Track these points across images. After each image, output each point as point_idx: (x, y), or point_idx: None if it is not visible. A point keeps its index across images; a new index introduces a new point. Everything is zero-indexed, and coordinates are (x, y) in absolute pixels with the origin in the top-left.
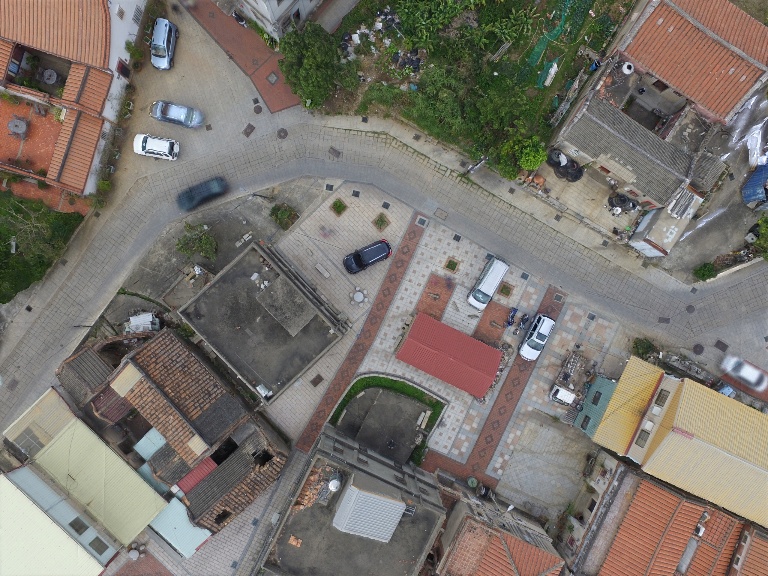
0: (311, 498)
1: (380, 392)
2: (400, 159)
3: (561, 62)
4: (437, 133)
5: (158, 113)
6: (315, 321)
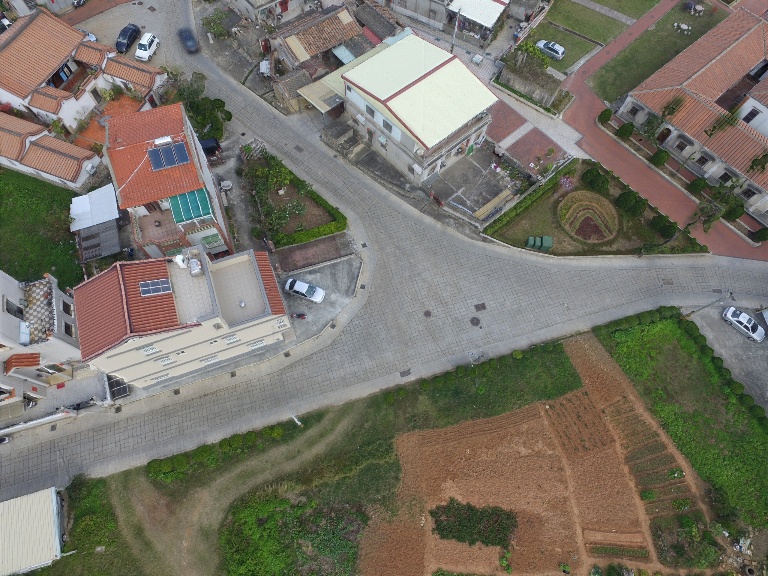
0: None
1: None
2: None
3: None
4: None
5: (125, 42)
6: None
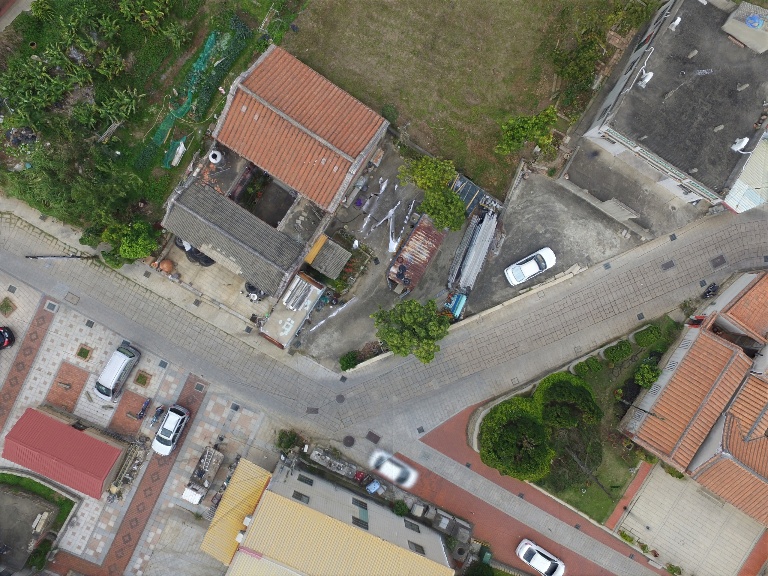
0: None
1: None
2: (27, 240)
3: (189, 141)
4: (53, 215)
5: None
6: None
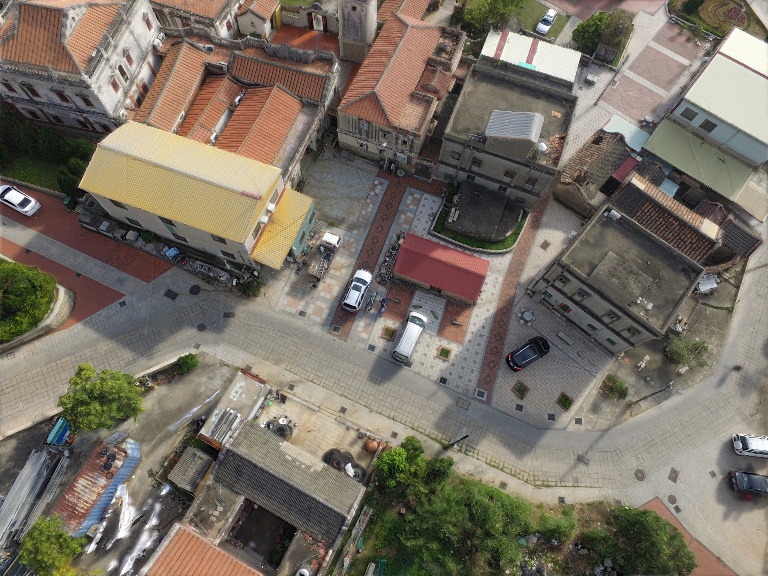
0: (553, 142)
1: None
2: (515, 459)
3: None
4: None
5: None
6: (586, 273)
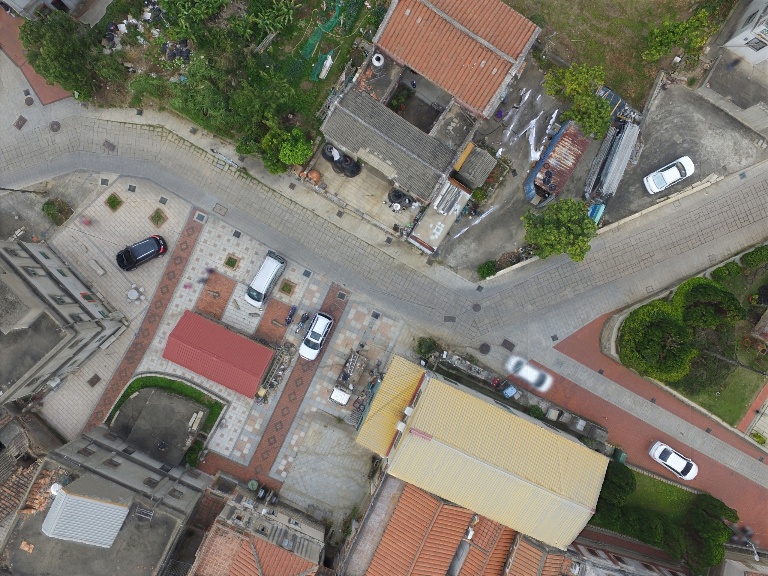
0: (42, 502)
1: (152, 392)
2: (177, 153)
3: (336, 54)
4: (207, 126)
5: None
6: (47, 319)
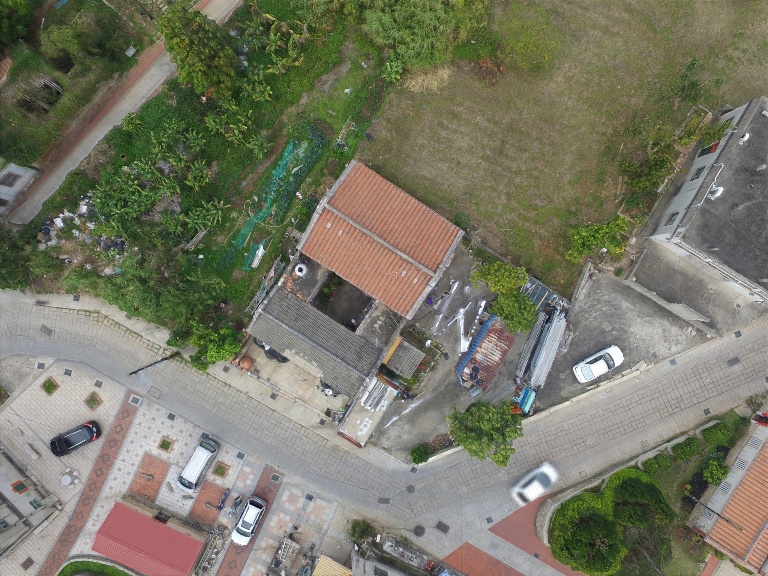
0: None
1: None
2: (113, 337)
3: (268, 244)
4: None
5: None
6: None
